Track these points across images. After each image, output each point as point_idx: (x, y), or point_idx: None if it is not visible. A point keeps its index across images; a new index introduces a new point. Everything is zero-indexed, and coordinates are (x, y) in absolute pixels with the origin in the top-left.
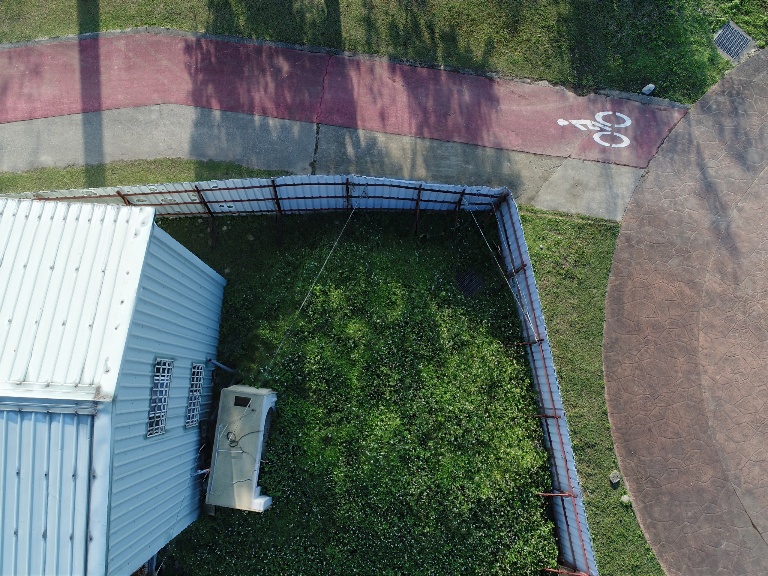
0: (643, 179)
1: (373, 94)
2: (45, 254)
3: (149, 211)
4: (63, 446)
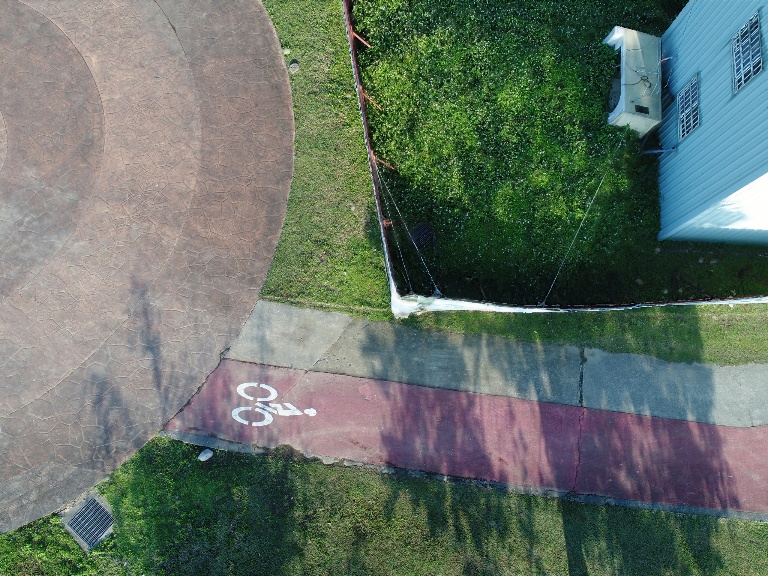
0: (228, 346)
1: (524, 443)
2: None
3: None
4: None
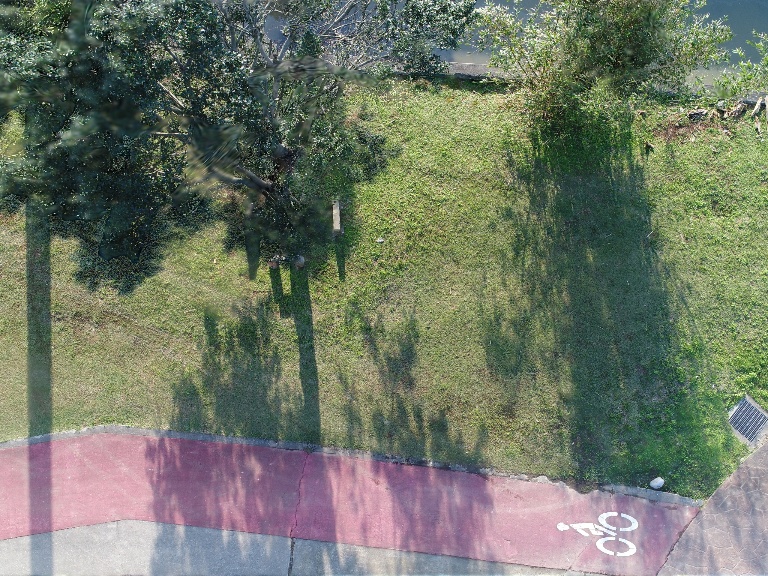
0: None
1: (354, 500)
2: None
3: None
4: None
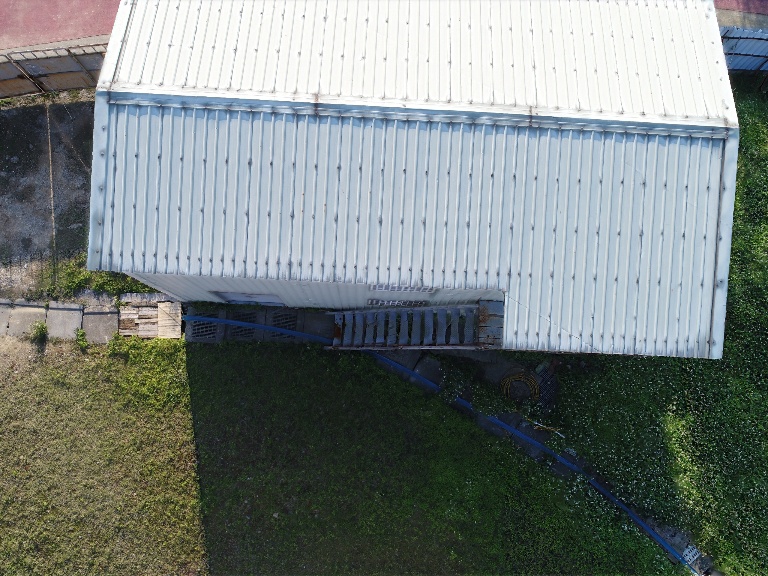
0: None
1: None
2: (643, 29)
3: (710, 1)
4: (700, 164)
